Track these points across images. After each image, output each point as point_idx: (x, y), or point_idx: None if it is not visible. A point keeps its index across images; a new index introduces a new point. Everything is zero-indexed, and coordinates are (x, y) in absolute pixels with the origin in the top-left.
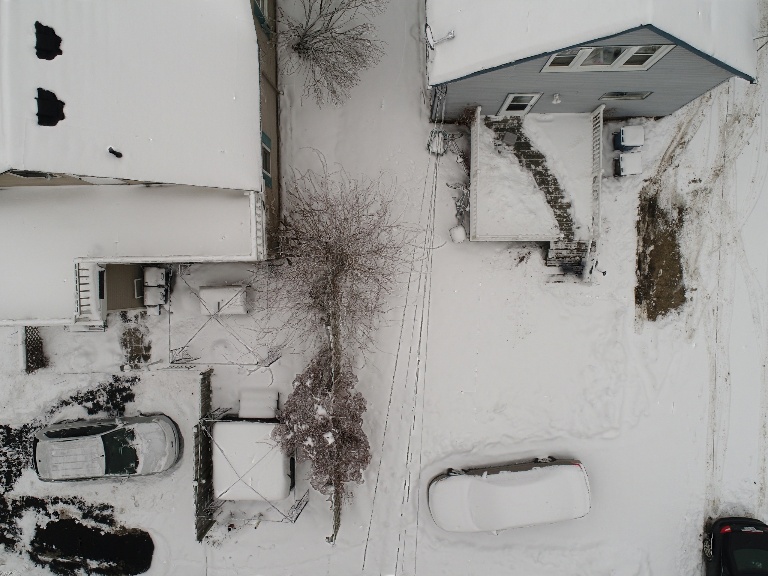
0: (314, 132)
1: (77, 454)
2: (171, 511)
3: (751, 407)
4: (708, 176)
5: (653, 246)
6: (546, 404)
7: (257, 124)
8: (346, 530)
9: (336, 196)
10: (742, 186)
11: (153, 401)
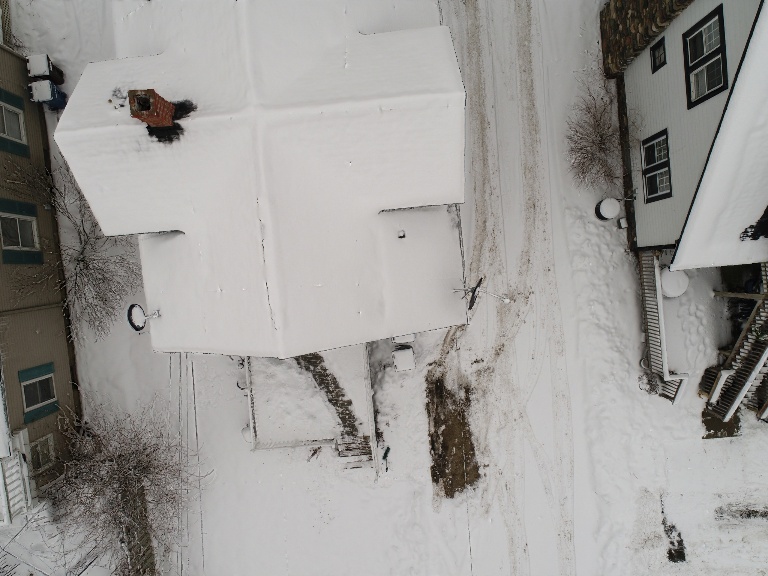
0: (106, 339)
1: None
2: None
3: (551, 575)
4: (490, 356)
5: (444, 426)
6: None
7: None
8: None
9: None
10: (522, 364)
11: None
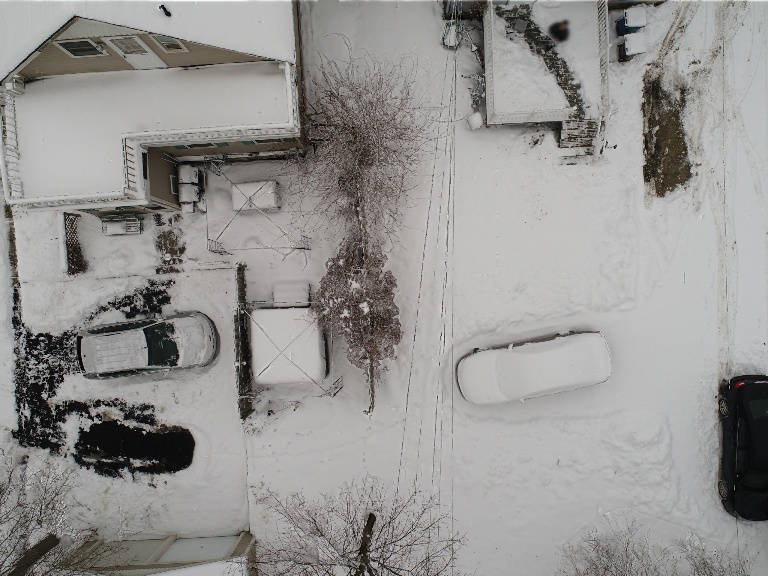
0: (334, 34)
1: (121, 347)
2: (210, 407)
3: (757, 273)
4: (707, 57)
5: (658, 126)
6: (565, 281)
7: None
8: (380, 412)
9: (361, 81)
10: (739, 65)
11: (189, 301)
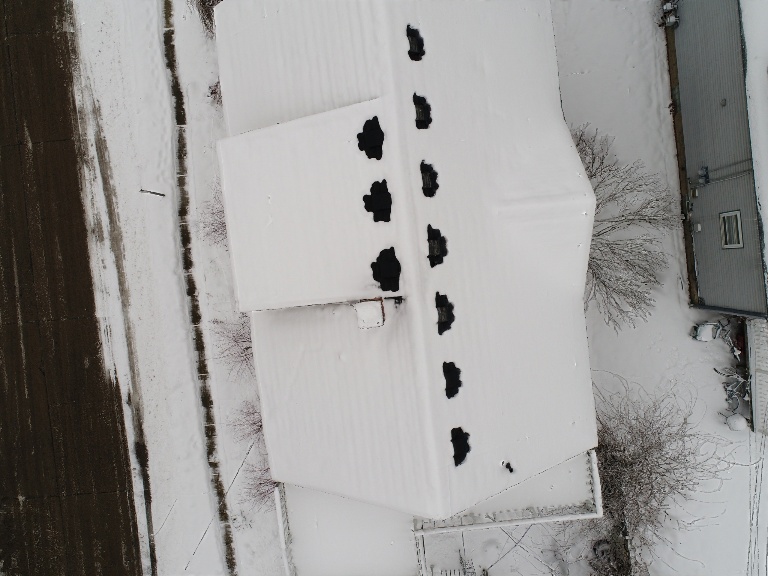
0: None
1: None
2: None
3: None
4: None
5: None
6: None
7: (590, 381)
8: None
9: (631, 412)
10: None
11: None
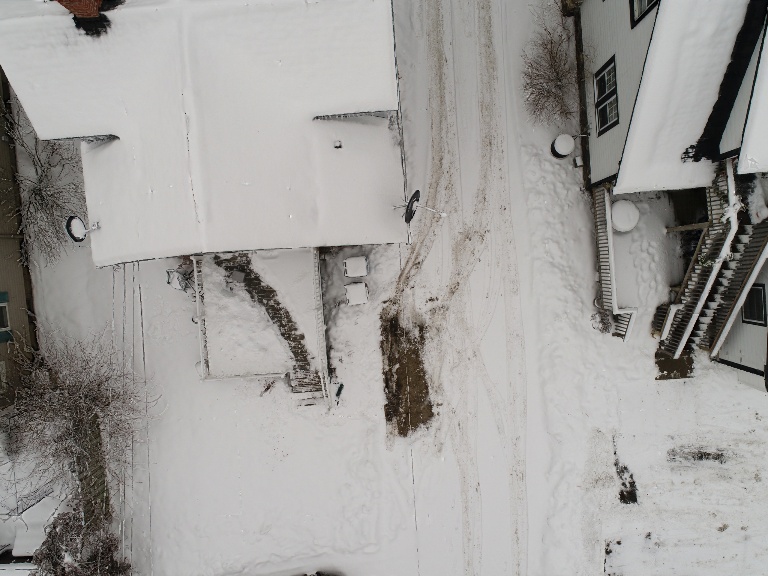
0: (63, 273)
1: None
2: None
3: (503, 515)
4: (444, 294)
5: (398, 364)
6: (308, 523)
7: None
8: None
9: None
10: (477, 302)
11: None
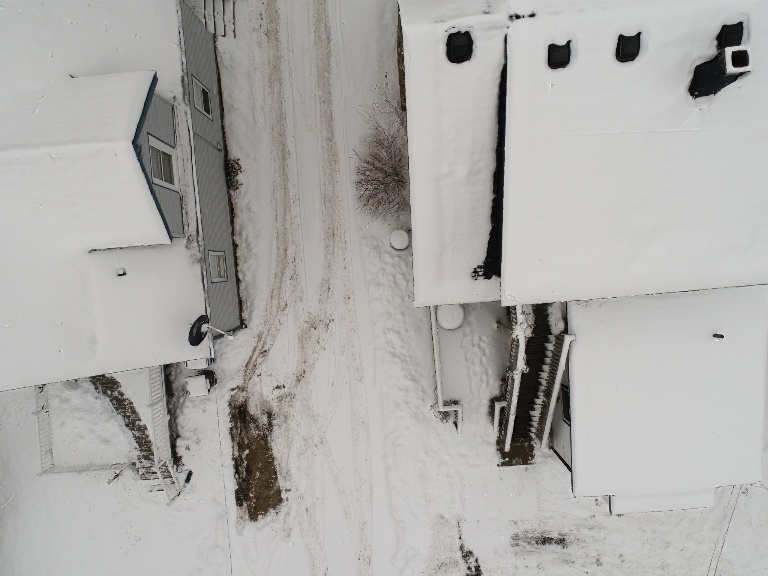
0: None
1: None
2: None
3: None
4: (291, 382)
5: (248, 450)
6: None
7: None
8: None
9: None
10: (322, 390)
11: None
